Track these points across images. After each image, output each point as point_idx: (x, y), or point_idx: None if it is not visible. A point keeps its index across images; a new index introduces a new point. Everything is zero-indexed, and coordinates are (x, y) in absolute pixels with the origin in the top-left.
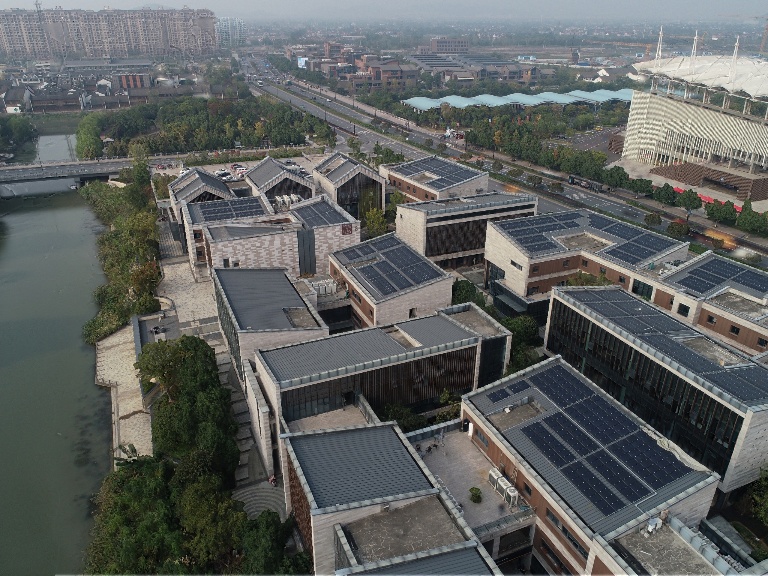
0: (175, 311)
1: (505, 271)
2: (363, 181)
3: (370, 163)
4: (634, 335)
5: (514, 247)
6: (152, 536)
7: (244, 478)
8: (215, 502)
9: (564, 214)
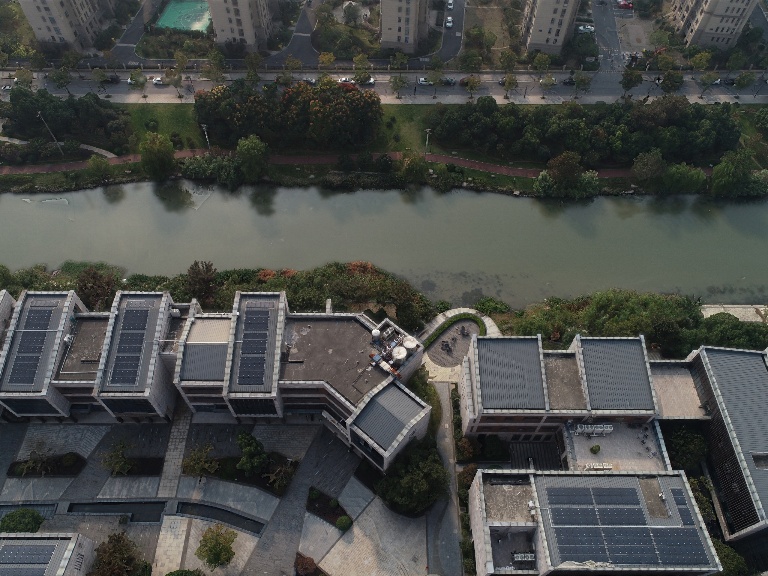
0: None
1: None
2: None
3: None
4: None
5: None
6: None
7: None
8: (634, 330)
9: None
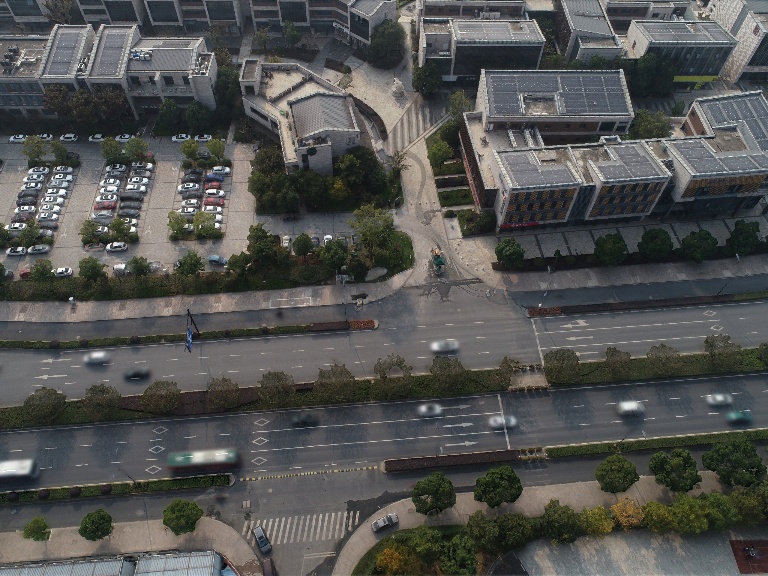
0: None
1: None
2: None
3: None
4: (558, 75)
5: None
6: None
7: None
8: None
9: None
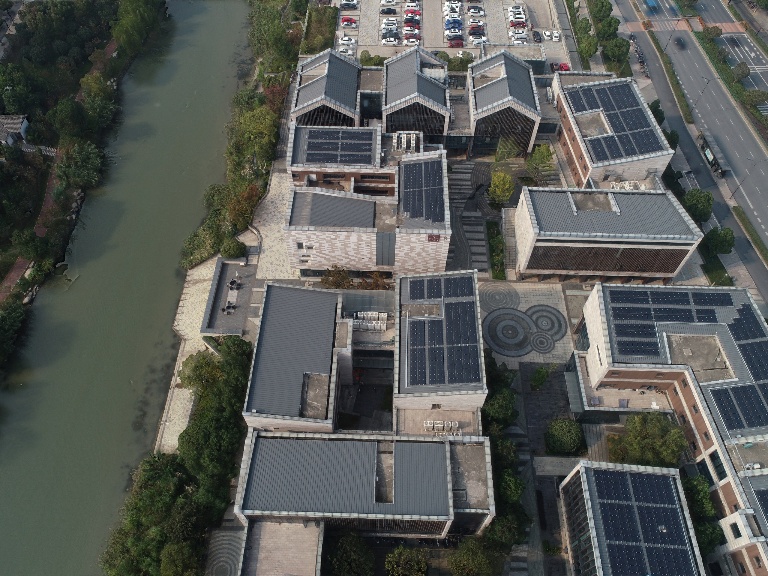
0: (258, 258)
1: (590, 346)
2: (512, 116)
3: (580, 8)
4: None
5: (603, 339)
6: (143, 560)
7: (230, 519)
8: (181, 570)
9: (710, 292)
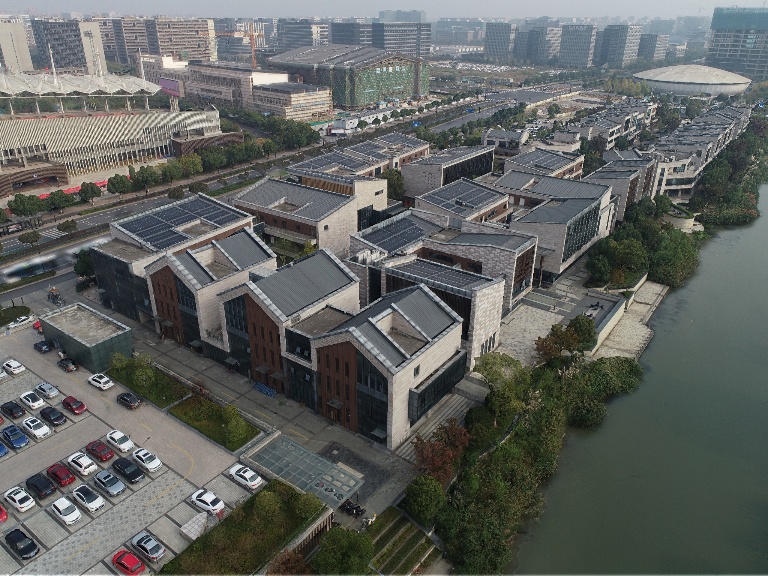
0: None
1: (373, 204)
2: None
3: None
4: None
5: (378, 181)
6: None
7: None
8: None
9: None
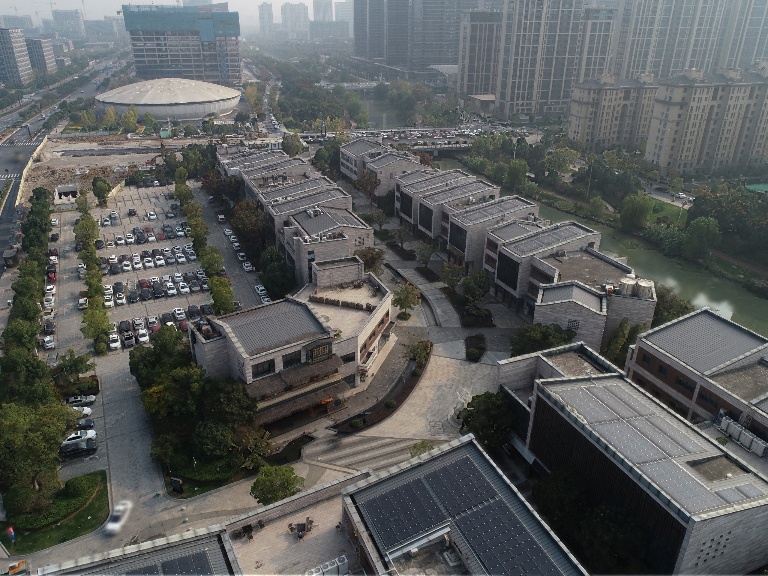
0: None
1: None
2: None
3: None
4: None
5: None
6: None
7: None
8: None
9: None
